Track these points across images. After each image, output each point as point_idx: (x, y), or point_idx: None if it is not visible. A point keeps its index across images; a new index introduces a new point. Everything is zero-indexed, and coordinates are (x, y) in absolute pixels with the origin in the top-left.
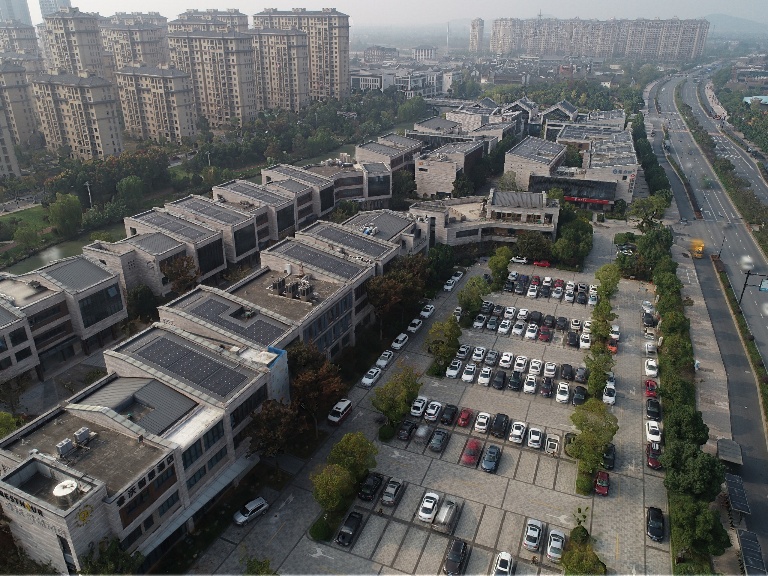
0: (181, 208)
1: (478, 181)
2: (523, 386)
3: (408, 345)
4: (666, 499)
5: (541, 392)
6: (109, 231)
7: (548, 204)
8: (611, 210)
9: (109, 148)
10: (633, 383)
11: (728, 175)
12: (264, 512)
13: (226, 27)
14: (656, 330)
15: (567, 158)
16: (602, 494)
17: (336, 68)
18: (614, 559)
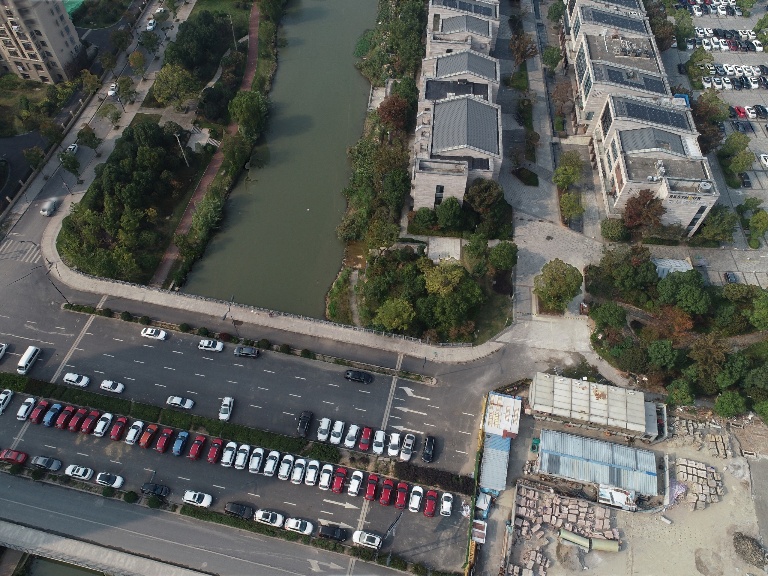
0: None
1: None
2: None
3: None
4: None
5: (763, 87)
6: None
7: None
8: None
9: None
10: None
11: None
12: None
13: None
14: None
15: None
16: None
17: None
18: None
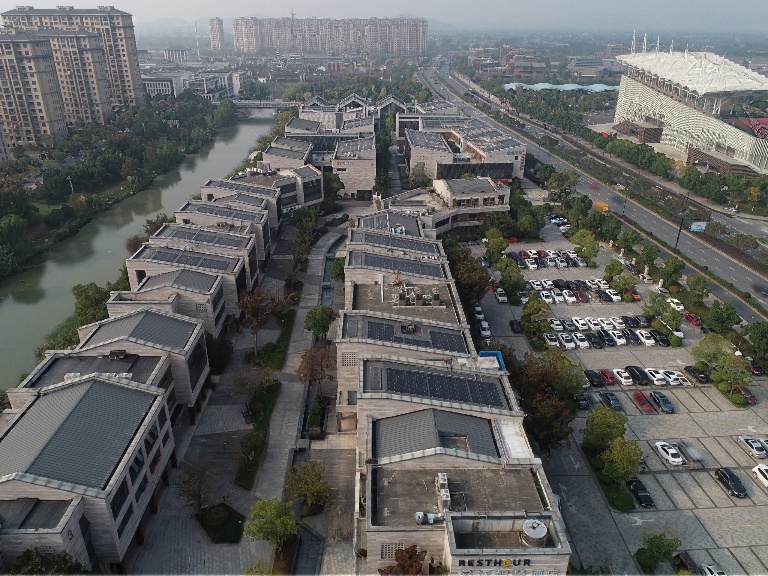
0: (175, 239)
1: None
2: None
3: (491, 331)
4: None
5: (633, 342)
6: None
7: (497, 186)
8: None
9: None
10: None
11: (560, 149)
12: None
13: (12, 28)
14: None
15: None
16: (754, 403)
17: (127, 73)
18: None
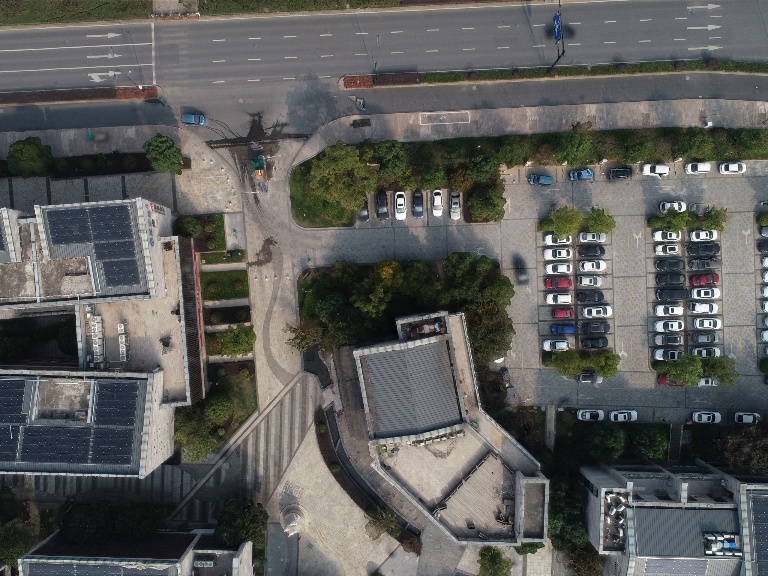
0: None
1: (161, 510)
2: None
3: None
4: None
5: None
6: None
7: None
8: None
9: None
10: (762, 184)
11: None
12: None
13: None
14: (654, 164)
15: None
16: None
17: None
18: None
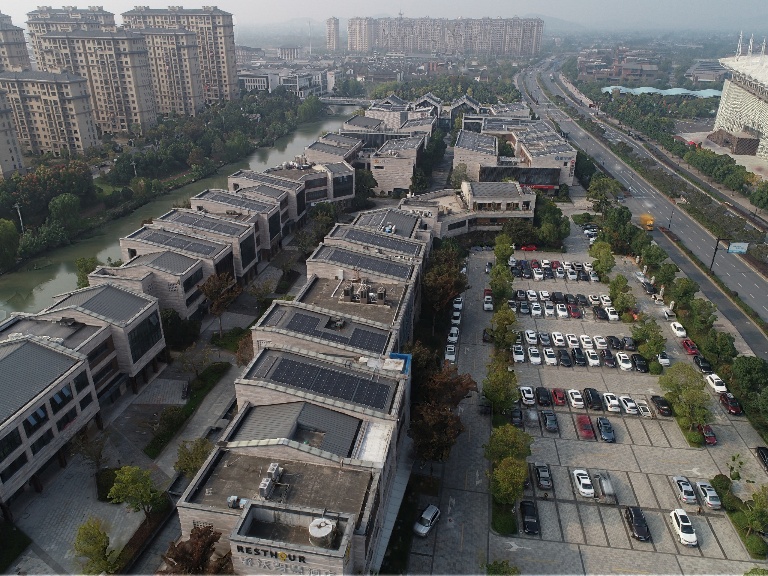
0: (175, 223)
1: (427, 175)
2: (587, 361)
3: (461, 337)
4: (760, 438)
5: (607, 364)
6: (47, 257)
7: (523, 192)
8: (555, 194)
9: (8, 164)
10: (671, 345)
11: (631, 156)
12: (438, 519)
13: None
14: (662, 296)
15: (498, 149)
16: (713, 444)
17: (224, 69)
18: None
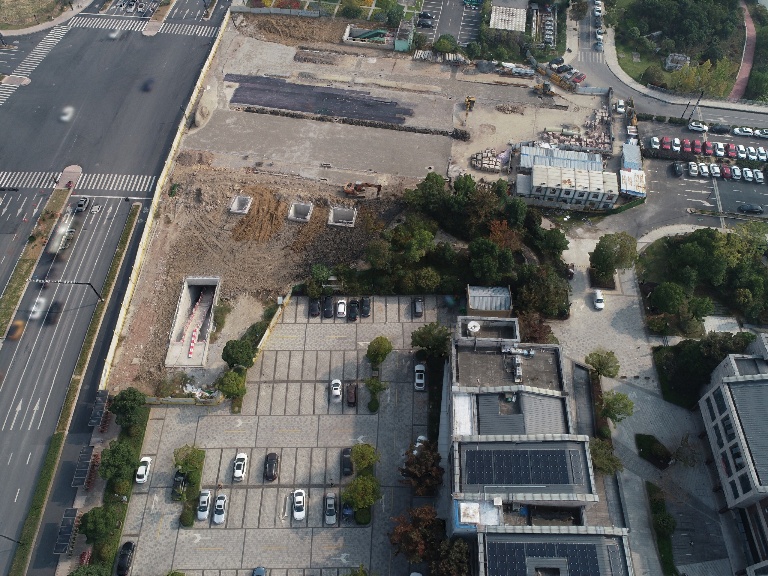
0: None
1: None
2: None
3: None
4: None
5: None
6: None
7: None
8: None
9: None
10: None
11: None
12: None
13: None
14: None
15: None
16: None
17: None
18: (165, 512)
